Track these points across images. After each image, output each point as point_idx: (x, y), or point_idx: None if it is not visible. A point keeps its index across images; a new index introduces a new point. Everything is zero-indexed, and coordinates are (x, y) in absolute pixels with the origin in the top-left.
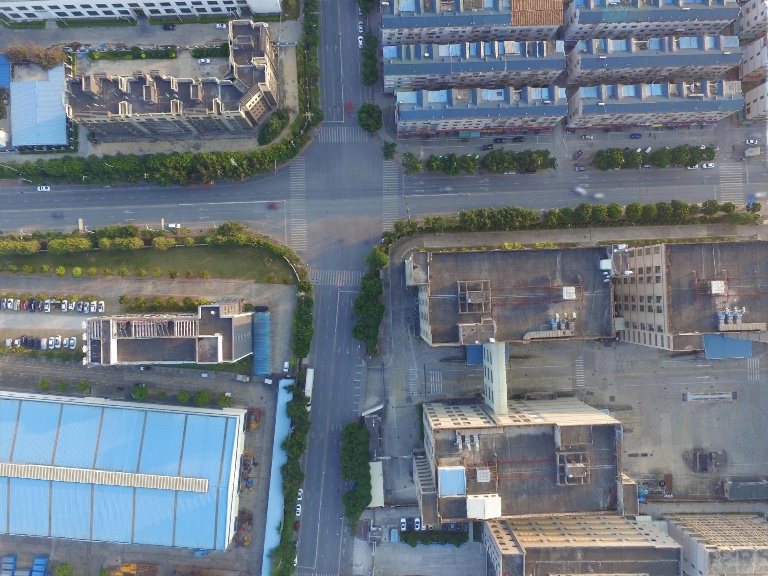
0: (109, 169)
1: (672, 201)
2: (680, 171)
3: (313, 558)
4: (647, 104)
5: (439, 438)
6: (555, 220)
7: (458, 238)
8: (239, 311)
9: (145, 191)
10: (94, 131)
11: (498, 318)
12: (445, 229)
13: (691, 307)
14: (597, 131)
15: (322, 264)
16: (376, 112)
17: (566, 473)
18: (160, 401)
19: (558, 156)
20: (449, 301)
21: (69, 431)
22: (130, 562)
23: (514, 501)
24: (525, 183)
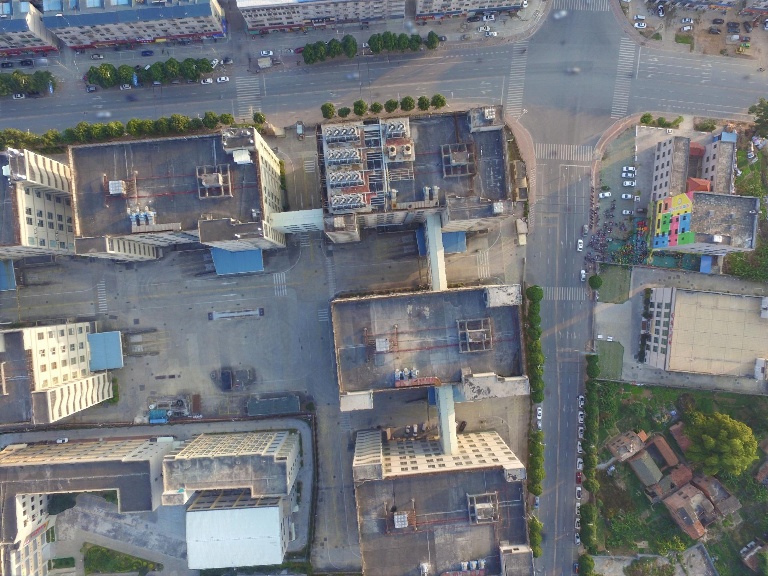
0: None
1: None
2: (195, 87)
3: None
4: (108, 13)
5: None
6: (53, 141)
7: None
8: None
9: None
10: None
11: None
12: None
13: (104, 211)
14: (108, 50)
15: None
16: None
17: None
18: None
19: (69, 78)
20: None
21: None
22: None
23: None
24: (37, 107)
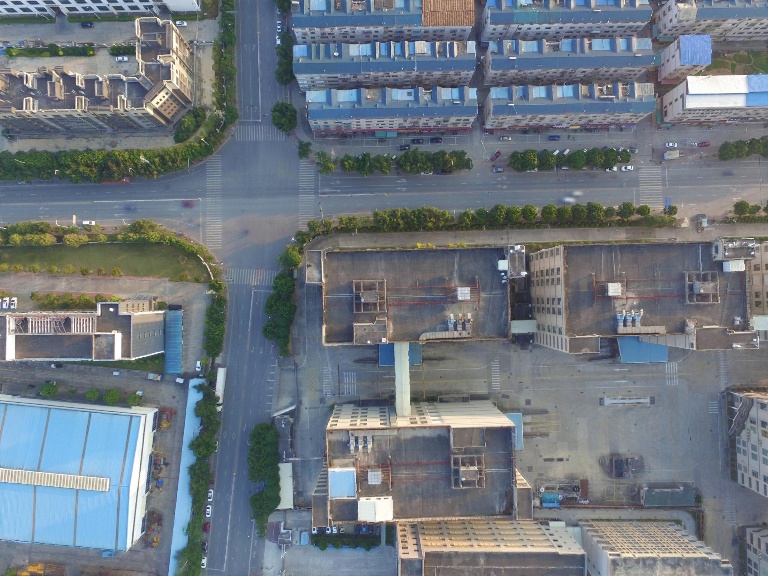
0: (21, 165)
1: (588, 203)
2: (599, 173)
3: (223, 560)
4: (557, 105)
5: (333, 439)
6: (469, 221)
7: (374, 238)
8: (149, 309)
9: (60, 188)
10: (6, 127)
11: (394, 318)
12: (360, 229)
13: (590, 309)
14: (515, 132)
15: (237, 263)
16: (289, 111)
17: (460, 476)
18: (71, 399)
19: (476, 157)
20: (345, 300)
21: None
22: (37, 562)
23: (408, 504)
24: (442, 184)
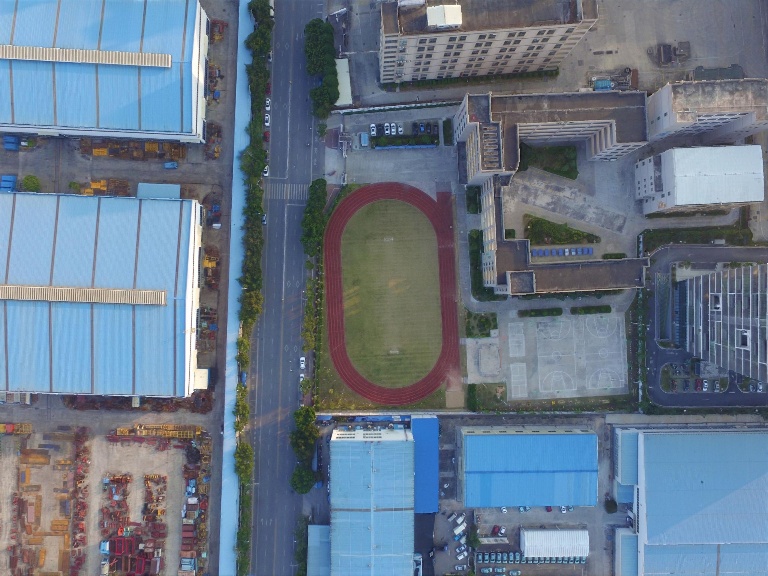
0: None
1: None
2: None
3: (284, 167)
4: None
5: None
6: None
7: None
8: None
9: None
10: None
11: None
12: None
13: None
14: None
15: None
16: None
17: None
18: None
19: None
20: None
21: (26, 14)
22: (100, 179)
23: (475, 18)
24: None
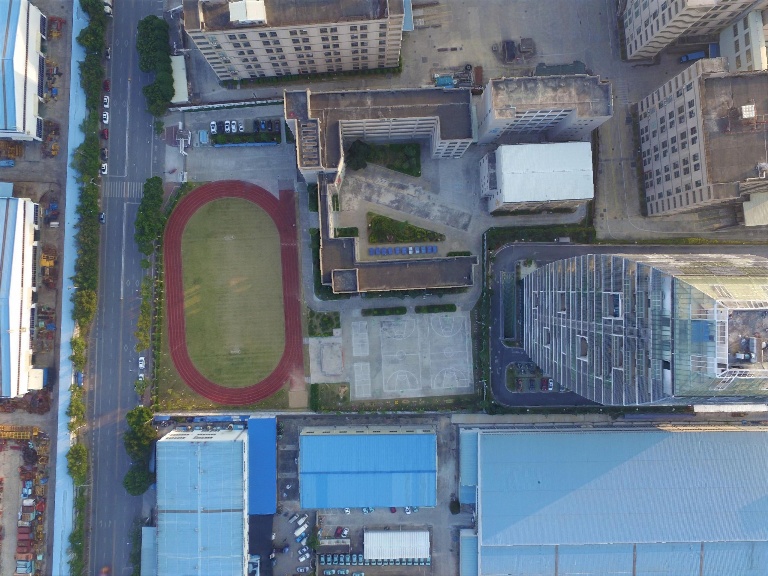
0: None
1: None
2: None
3: (123, 165)
4: None
5: None
6: None
7: None
8: None
9: None
10: None
11: None
12: None
13: None
14: None
15: None
16: None
17: None
18: None
19: None
20: None
21: None
22: None
23: (282, 14)
24: None
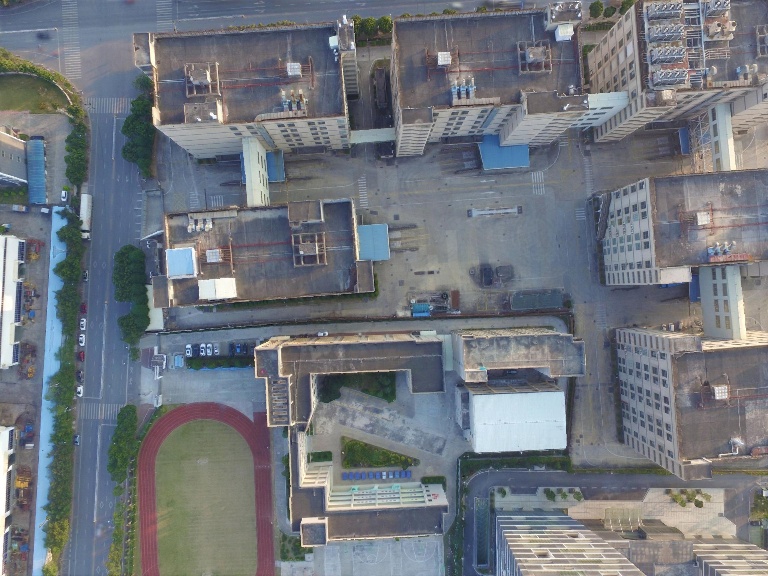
0: None
1: (443, 11)
2: None
3: (99, 388)
4: None
5: (173, 225)
6: None
7: None
8: None
9: None
10: None
11: (229, 102)
12: None
13: (425, 84)
14: None
15: (98, 92)
16: None
17: None
18: None
19: None
20: (178, 86)
21: None
22: None
23: (252, 286)
24: (301, 4)
